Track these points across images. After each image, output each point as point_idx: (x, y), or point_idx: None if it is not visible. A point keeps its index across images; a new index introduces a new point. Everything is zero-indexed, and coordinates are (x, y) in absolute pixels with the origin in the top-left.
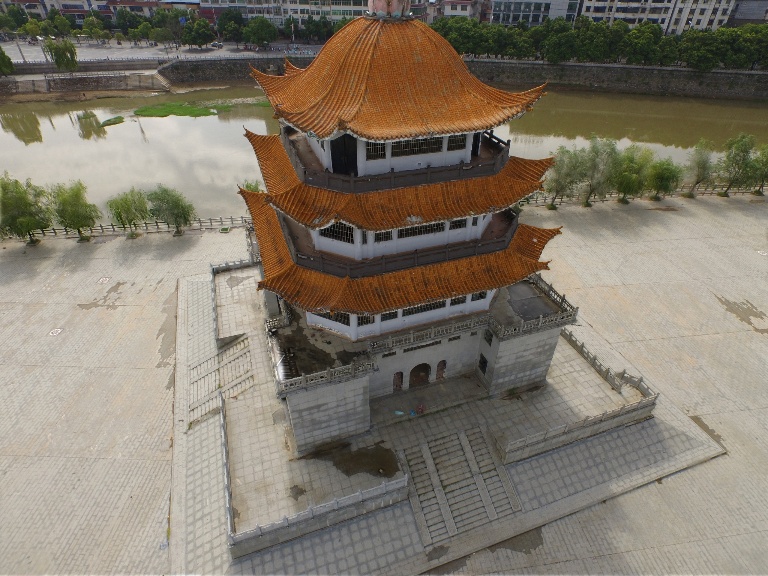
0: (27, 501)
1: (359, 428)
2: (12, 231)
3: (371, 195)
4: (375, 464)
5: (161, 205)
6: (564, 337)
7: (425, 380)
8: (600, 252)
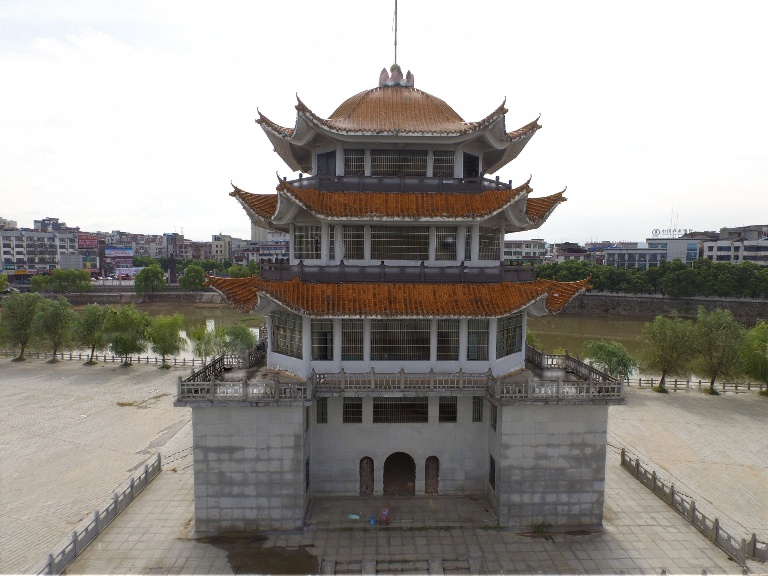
0: None
1: (287, 518)
2: (113, 349)
3: (336, 195)
4: (283, 568)
5: (235, 340)
6: (646, 485)
7: (410, 491)
8: (730, 432)
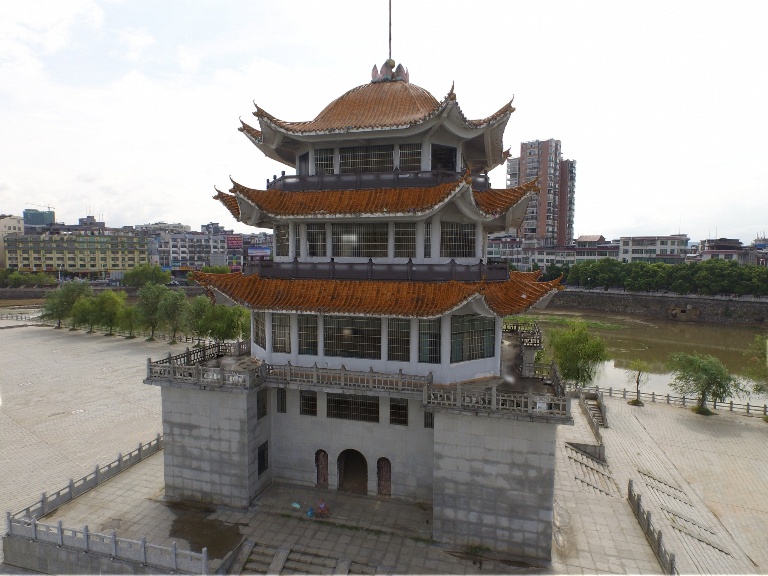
0: (4, 466)
1: (235, 496)
2: (212, 335)
3: (297, 194)
4: (208, 540)
5: None
6: (642, 527)
7: (365, 490)
8: None
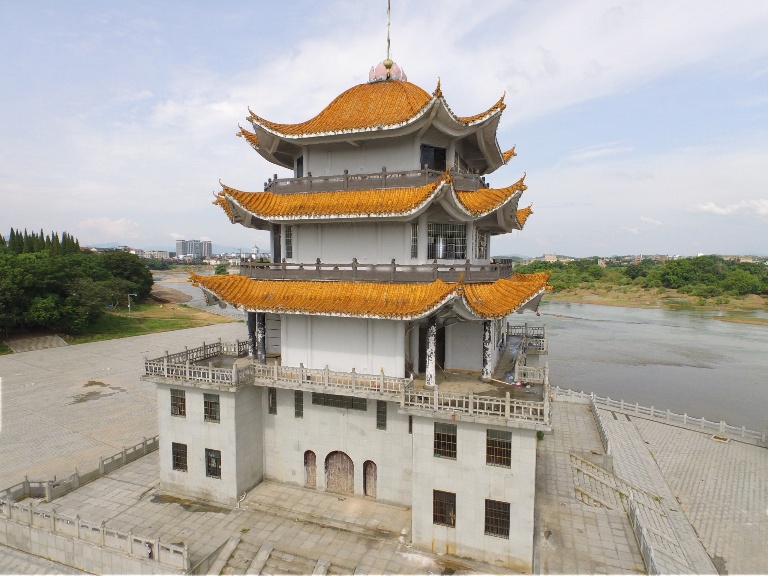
0: None
1: None
2: None
3: None
4: None
5: None
6: None
7: None
8: None
